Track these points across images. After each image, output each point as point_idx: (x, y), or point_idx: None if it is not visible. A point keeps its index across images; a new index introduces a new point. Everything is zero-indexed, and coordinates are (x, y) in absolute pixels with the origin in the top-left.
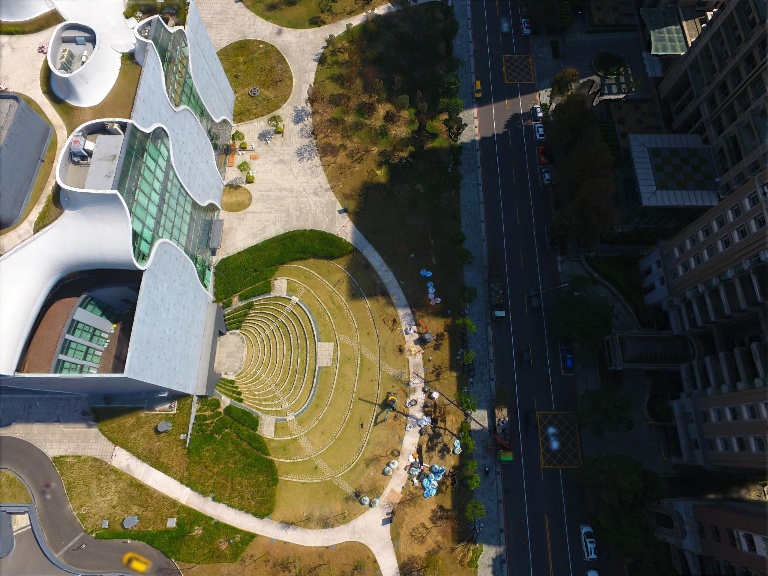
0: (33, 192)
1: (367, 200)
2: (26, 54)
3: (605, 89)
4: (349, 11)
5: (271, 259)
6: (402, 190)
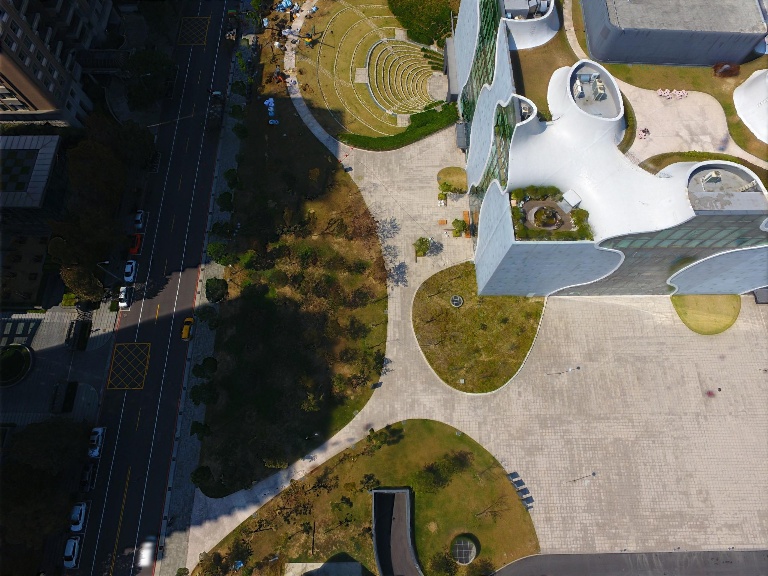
0: (580, 8)
1: (324, 181)
2: (660, 128)
3: (32, 329)
4: (347, 461)
5: (412, 133)
6: (290, 197)
